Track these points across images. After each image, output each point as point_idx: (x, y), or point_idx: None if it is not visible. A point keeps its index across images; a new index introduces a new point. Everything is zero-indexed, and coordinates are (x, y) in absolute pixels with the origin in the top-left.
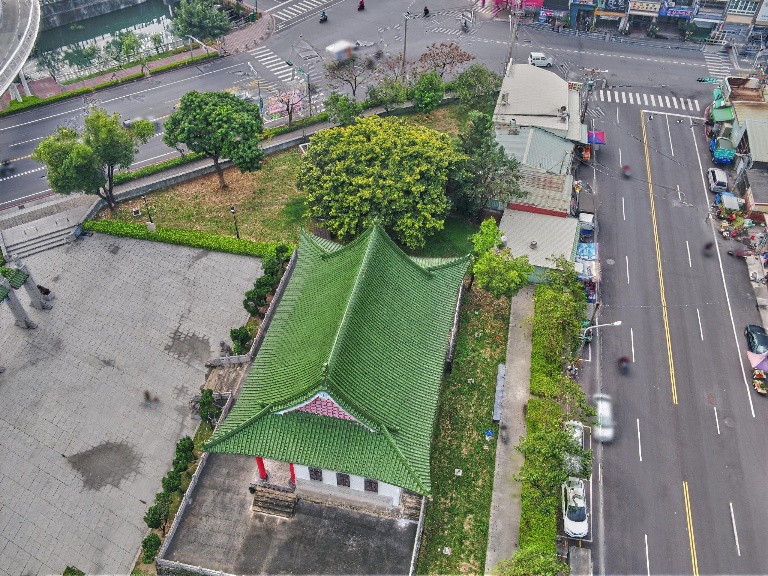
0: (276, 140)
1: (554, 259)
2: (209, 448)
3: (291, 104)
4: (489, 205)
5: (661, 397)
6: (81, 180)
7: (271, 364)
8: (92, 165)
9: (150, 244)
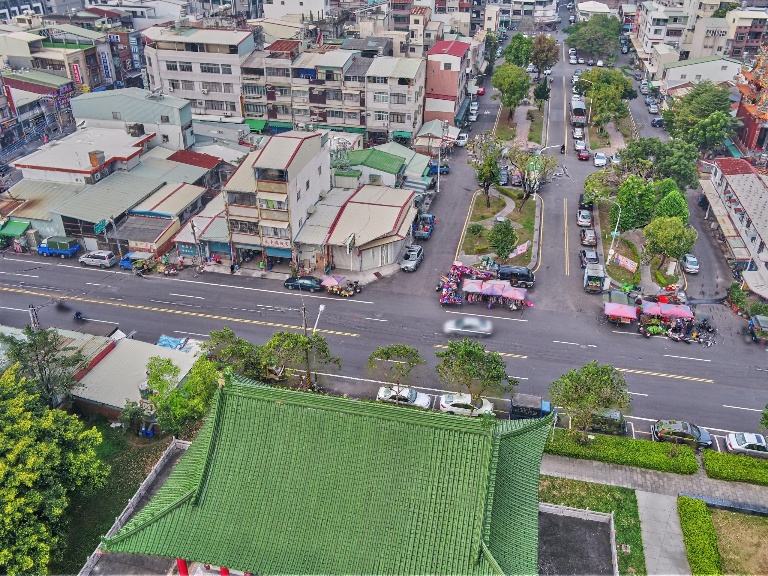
0: None
1: (202, 347)
2: None
3: None
4: (83, 385)
5: (352, 342)
6: None
7: (393, 567)
8: None
9: None
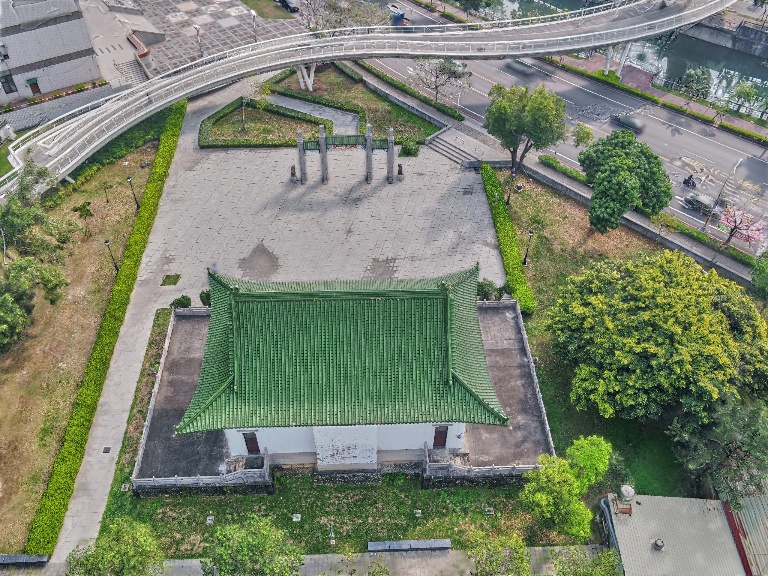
0: (693, 244)
1: None
2: (210, 276)
3: (737, 226)
4: (679, 461)
5: None
6: (497, 129)
7: None
8: (506, 123)
9: (486, 209)
